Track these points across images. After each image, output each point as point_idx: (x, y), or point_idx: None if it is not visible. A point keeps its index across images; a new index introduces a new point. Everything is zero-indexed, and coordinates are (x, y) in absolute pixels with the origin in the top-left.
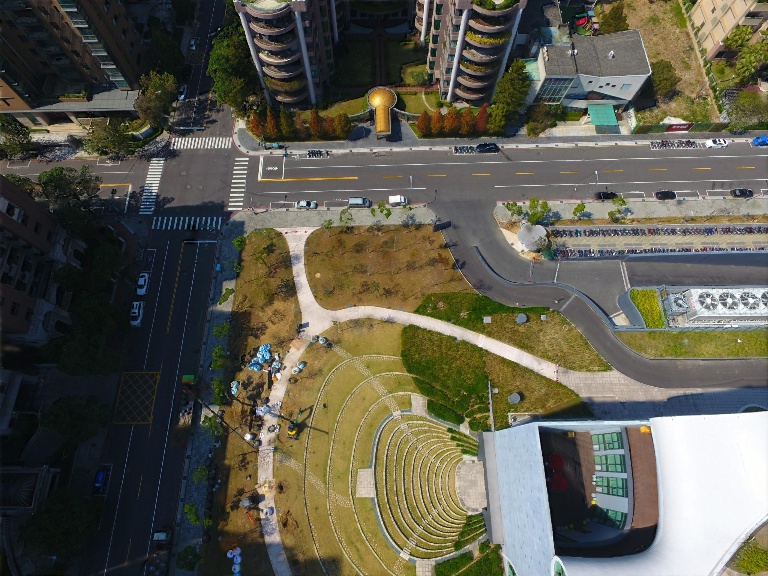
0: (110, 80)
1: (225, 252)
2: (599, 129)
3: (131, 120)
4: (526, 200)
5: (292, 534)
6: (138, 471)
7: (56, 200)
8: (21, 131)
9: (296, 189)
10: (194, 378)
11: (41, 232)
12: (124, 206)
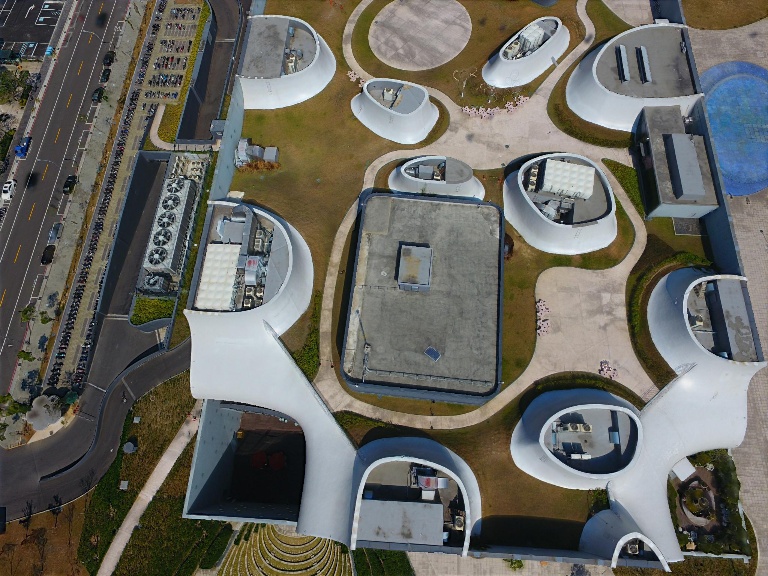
0: None
1: None
2: None
3: None
4: None
5: None
6: None
7: None
8: None
9: None
10: None
11: None
12: None
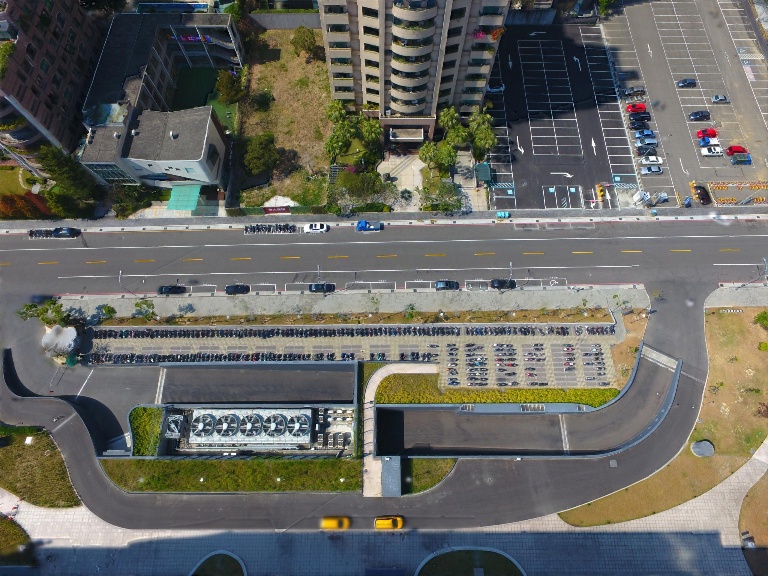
0: None
1: None
2: (196, 210)
3: None
4: (85, 294)
5: None
6: None
7: None
8: None
9: None
10: None
11: None
12: None
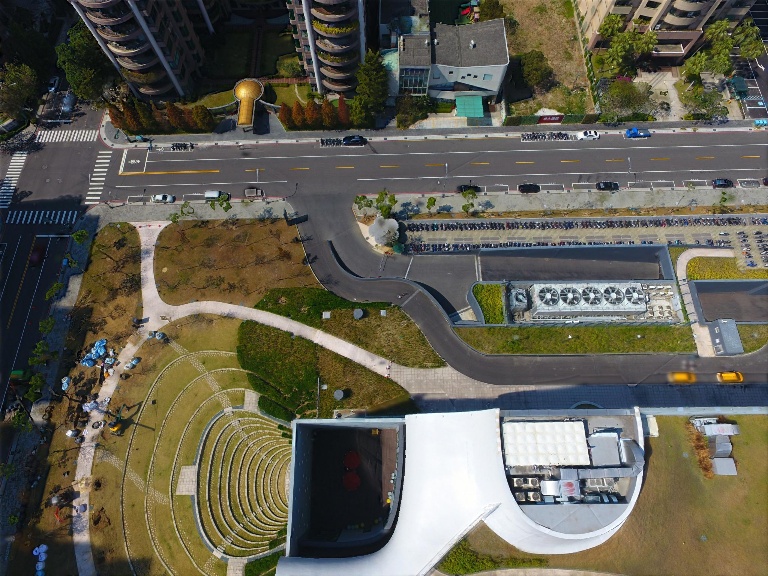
0: None
1: (76, 246)
2: (471, 121)
3: None
4: (387, 193)
5: (102, 531)
6: None
7: None
8: None
9: (156, 182)
10: (23, 374)
11: None
12: None
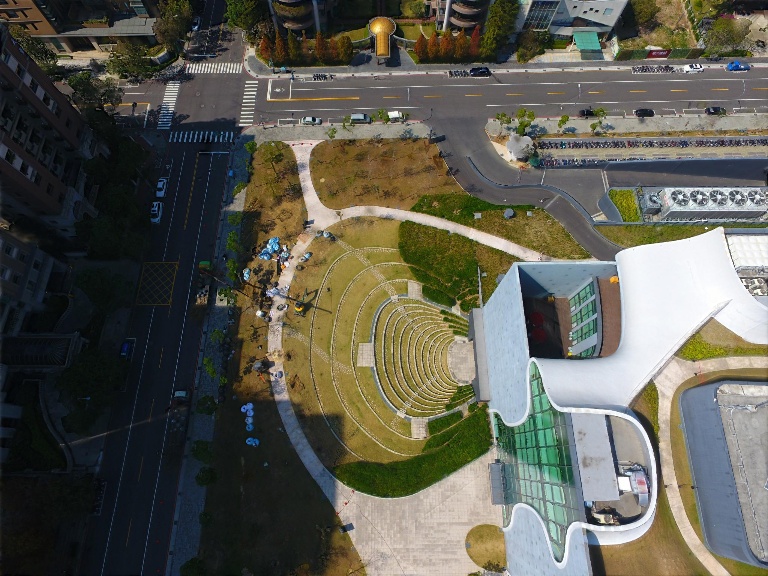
0: (130, 8)
1: (237, 161)
2: (584, 56)
3: (149, 48)
4: (515, 117)
5: (299, 393)
6: (159, 344)
7: (83, 106)
8: (48, 51)
9: (302, 108)
10: (210, 264)
11: (71, 128)
12: (143, 122)
